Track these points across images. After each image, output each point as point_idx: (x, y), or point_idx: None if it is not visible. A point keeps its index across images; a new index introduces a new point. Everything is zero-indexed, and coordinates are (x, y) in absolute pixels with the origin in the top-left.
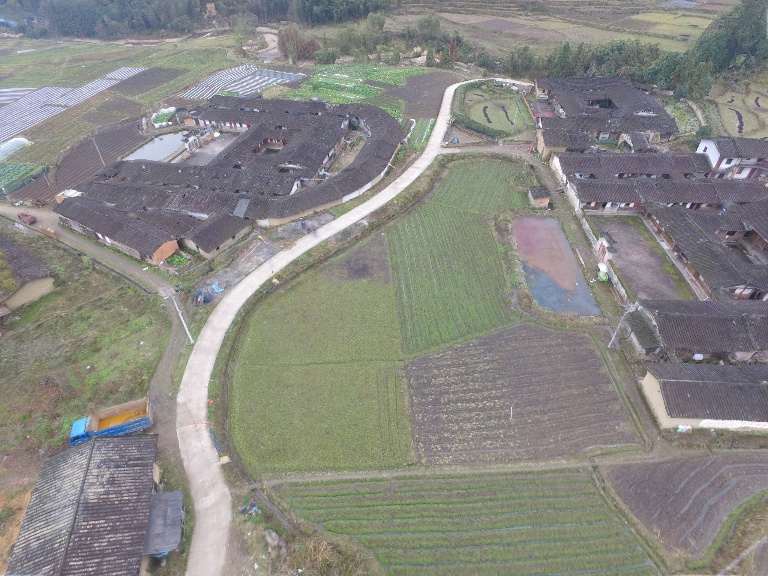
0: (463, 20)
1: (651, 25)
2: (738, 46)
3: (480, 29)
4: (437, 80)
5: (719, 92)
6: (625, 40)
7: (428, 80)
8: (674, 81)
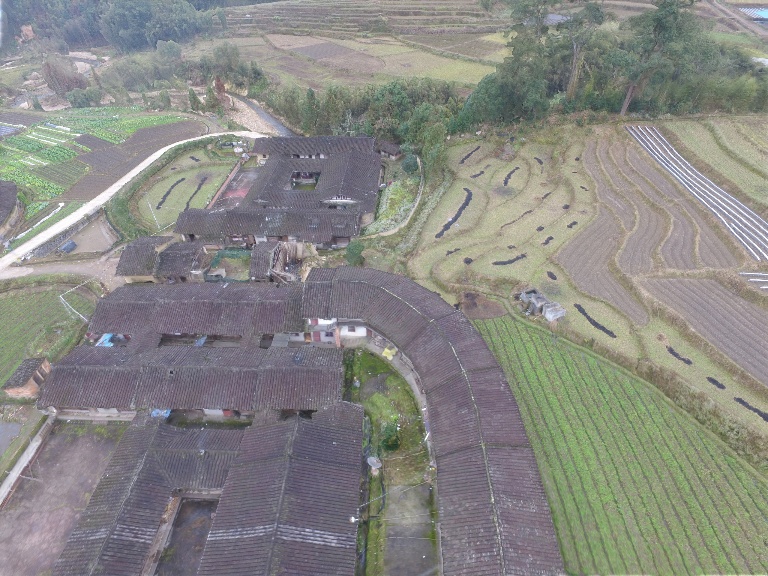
0: (288, 44)
1: (495, 49)
2: (513, 93)
3: (297, 56)
4: (171, 134)
5: (482, 156)
6: (448, 71)
7: (160, 134)
8: (421, 143)
